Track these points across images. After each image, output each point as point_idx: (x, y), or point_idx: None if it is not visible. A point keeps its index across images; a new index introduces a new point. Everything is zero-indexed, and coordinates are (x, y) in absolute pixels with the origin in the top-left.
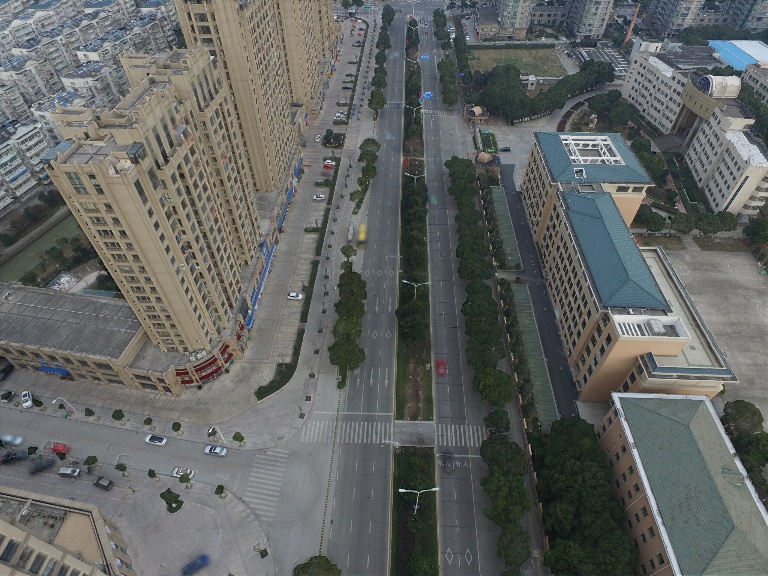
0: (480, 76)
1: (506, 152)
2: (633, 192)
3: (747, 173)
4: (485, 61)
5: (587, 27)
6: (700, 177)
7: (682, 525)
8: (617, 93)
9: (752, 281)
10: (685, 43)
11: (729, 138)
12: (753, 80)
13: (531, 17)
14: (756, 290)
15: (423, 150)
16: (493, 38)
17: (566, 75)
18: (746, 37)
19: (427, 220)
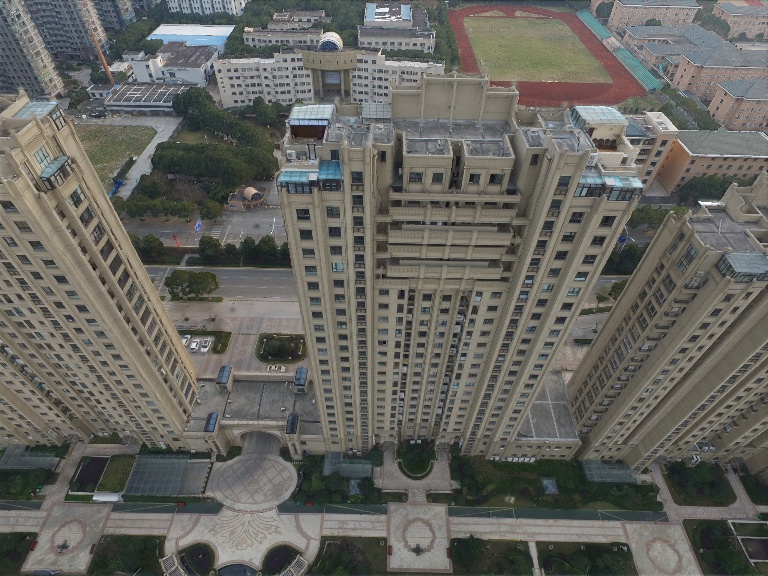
0: (157, 177)
1: None
2: None
3: None
4: None
5: (50, 84)
6: None
7: (759, 149)
8: (262, 98)
9: None
10: (146, 50)
11: None
12: (265, 42)
13: None
14: None
15: None
16: None
17: (217, 113)
18: (150, 26)
19: None
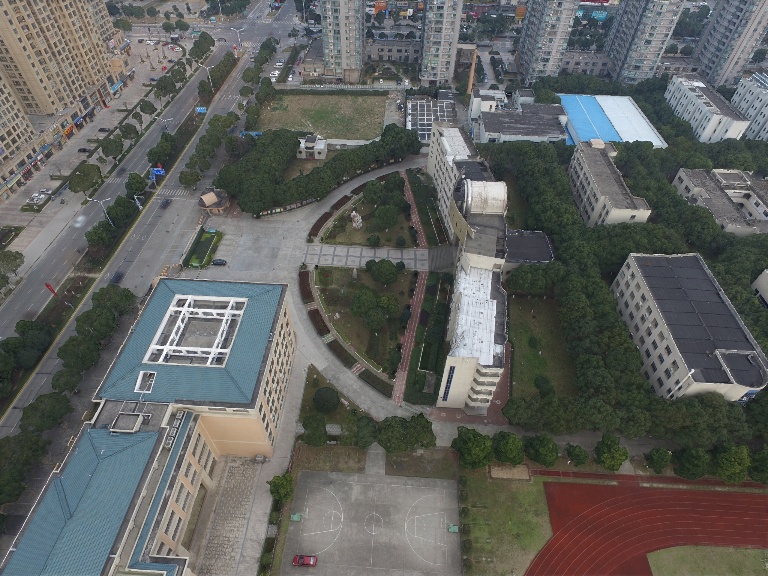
0: (248, 142)
1: (219, 266)
2: (236, 411)
3: (450, 363)
4: (291, 113)
5: (430, 70)
6: (448, 326)
7: None
8: (397, 179)
9: (428, 549)
10: (536, 98)
11: (465, 286)
12: (579, 165)
13: (378, 52)
14: (424, 572)
15: (108, 260)
16: (319, 79)
17: (342, 150)
18: (616, 91)
19: (16, 399)
